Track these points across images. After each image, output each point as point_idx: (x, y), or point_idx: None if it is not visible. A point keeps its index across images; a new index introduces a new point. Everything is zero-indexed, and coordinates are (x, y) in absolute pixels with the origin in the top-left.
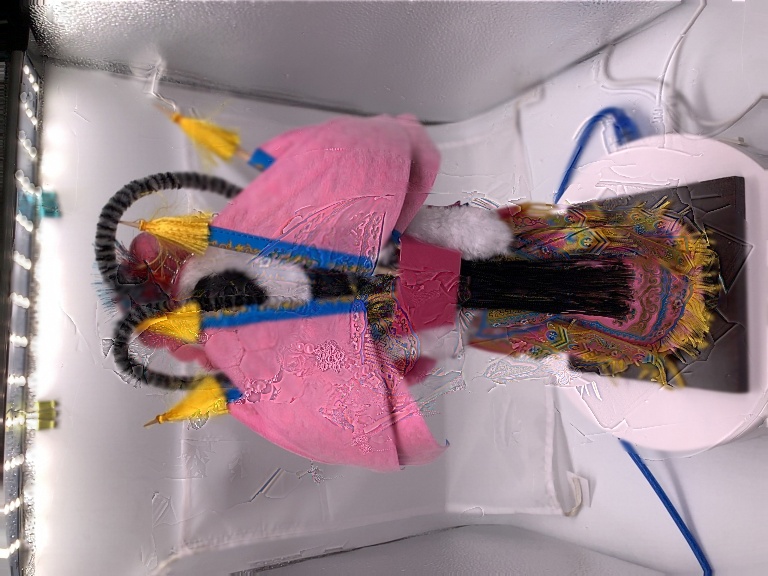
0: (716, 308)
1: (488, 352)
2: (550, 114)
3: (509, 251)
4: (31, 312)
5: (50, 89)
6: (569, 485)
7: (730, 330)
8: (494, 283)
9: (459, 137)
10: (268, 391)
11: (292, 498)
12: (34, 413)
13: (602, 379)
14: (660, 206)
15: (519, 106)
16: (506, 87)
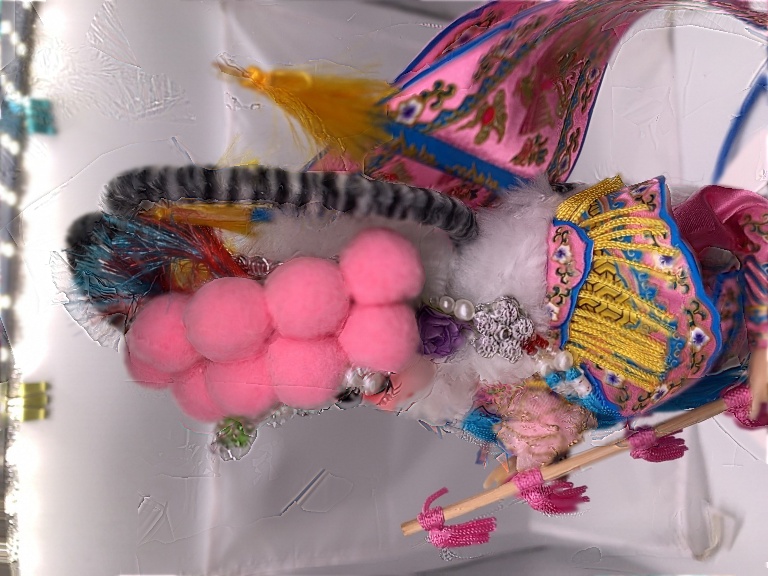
0: None
1: None
2: None
3: None
4: None
5: None
6: (702, 518)
7: None
8: None
9: None
10: None
11: (338, 514)
12: None
13: None
14: None
15: None
16: None
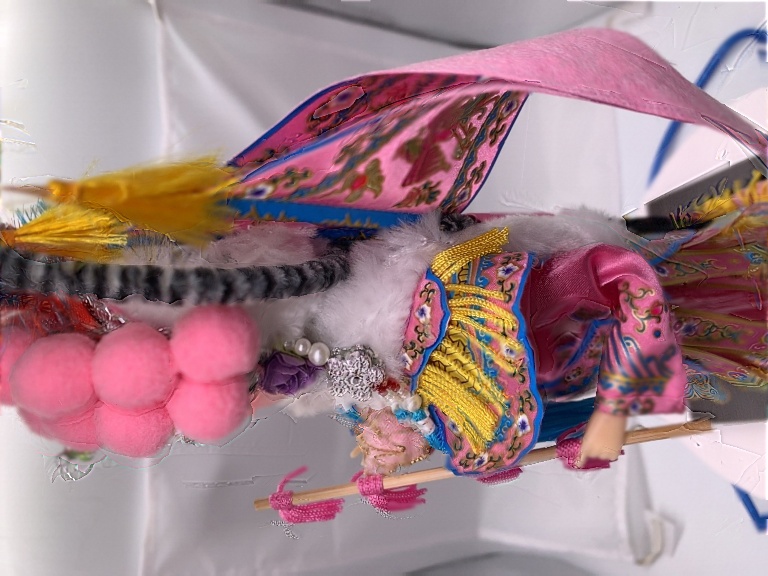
0: None
1: (641, 416)
2: None
3: None
4: None
5: None
6: None
7: None
8: None
9: None
10: None
11: None
12: None
13: None
14: None
15: None
16: None
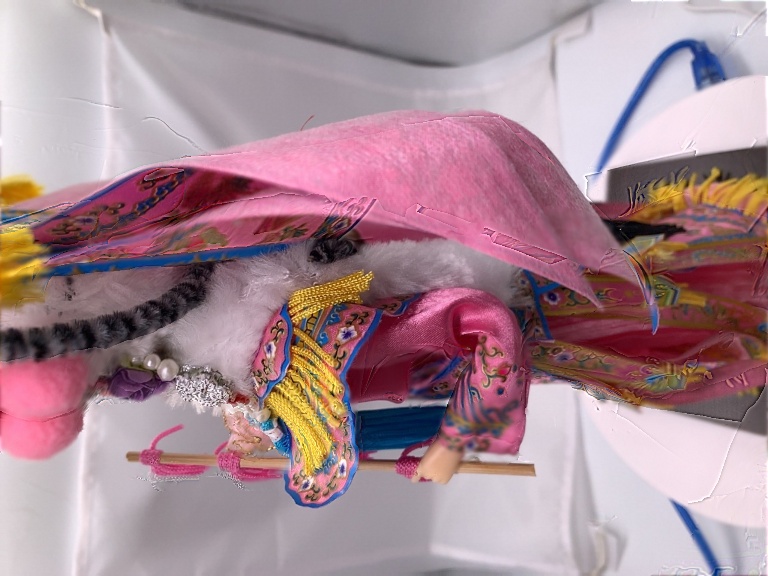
0: None
1: (476, 453)
2: None
3: None
4: None
5: None
6: None
7: None
8: None
9: None
10: None
11: None
12: None
13: None
14: None
15: None
16: None
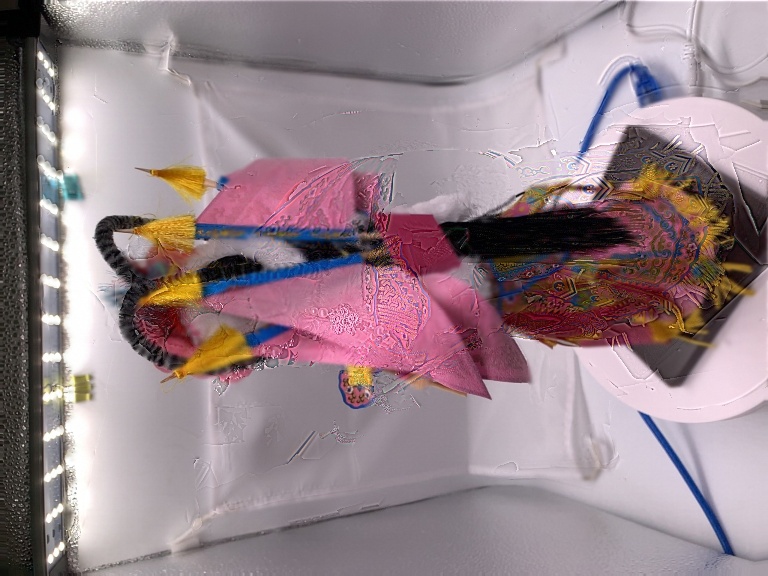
0: (747, 250)
1: (503, 307)
2: (572, 59)
3: (506, 203)
4: (62, 292)
5: (64, 73)
6: (606, 438)
7: (763, 272)
8: (494, 237)
9: (478, 90)
10: (285, 356)
11: (328, 459)
12: (70, 387)
13: (633, 330)
14: (672, 147)
15: (540, 53)
16: (525, 34)
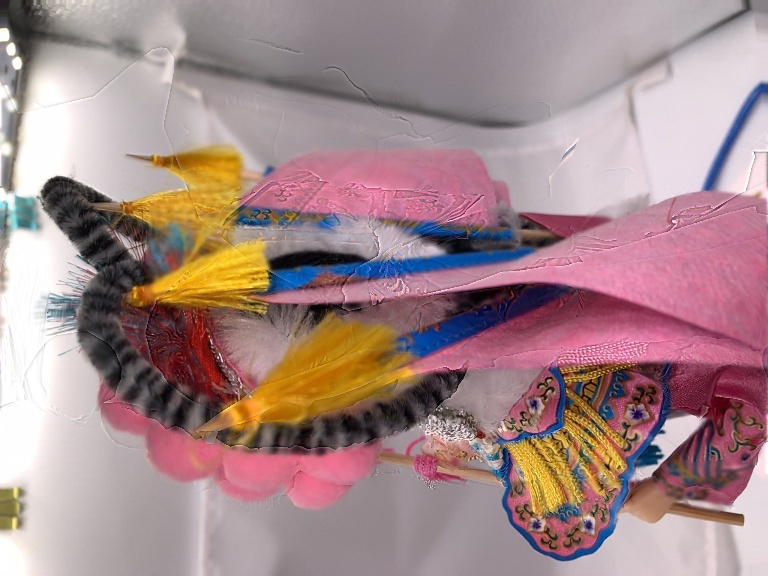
0: None
1: (690, 499)
2: None
3: None
4: None
5: None
6: None
7: None
8: None
9: None
10: None
11: None
12: None
13: None
14: None
15: None
16: None
